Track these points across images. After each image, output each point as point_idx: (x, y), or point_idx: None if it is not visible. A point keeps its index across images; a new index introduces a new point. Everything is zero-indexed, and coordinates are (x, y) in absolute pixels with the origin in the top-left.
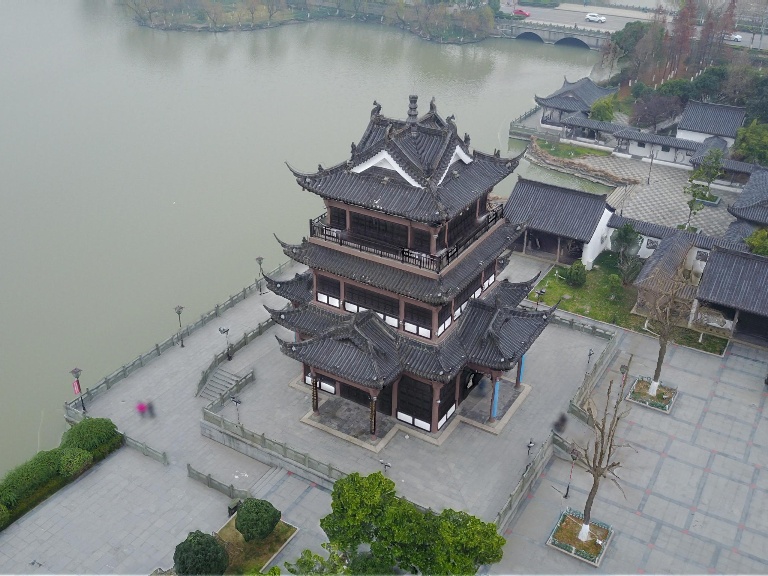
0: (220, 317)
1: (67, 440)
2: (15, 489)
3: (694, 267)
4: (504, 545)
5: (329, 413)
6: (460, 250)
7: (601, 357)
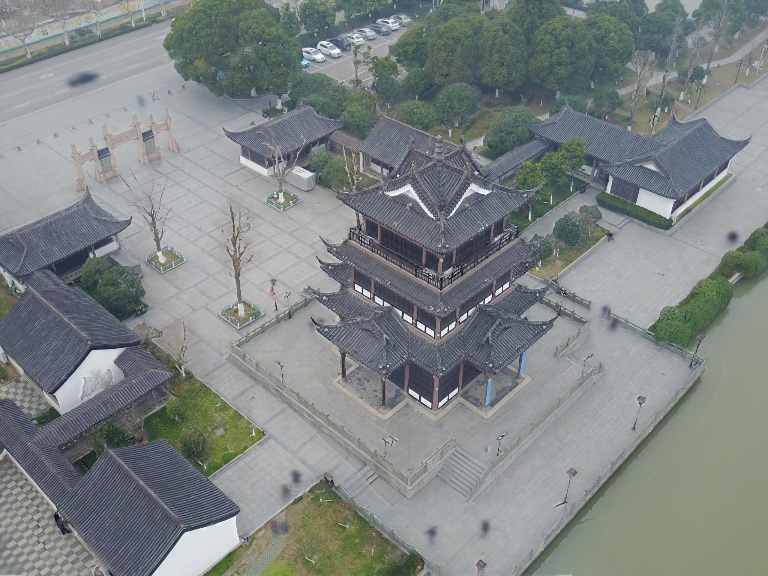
0: None
1: (685, 325)
2: None
3: None
4: None
5: None
6: None
7: (267, 322)
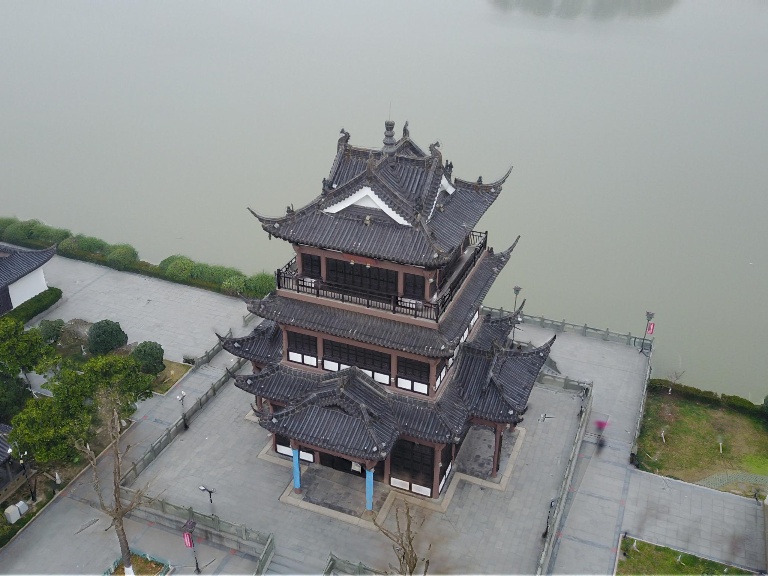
0: None
1: None
2: None
3: None
4: (133, 520)
5: None
6: (325, 293)
7: None
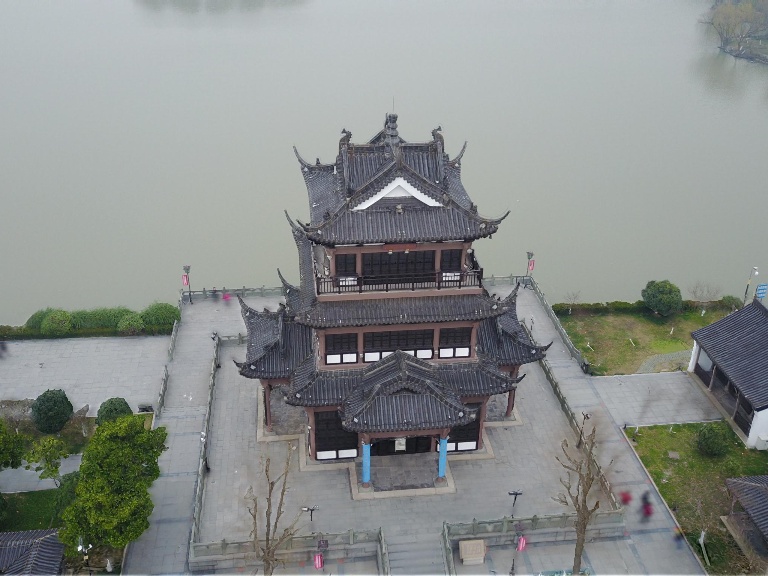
0: None
1: None
2: (86, 319)
3: None
4: (221, 574)
5: None
6: (368, 287)
7: (557, 515)
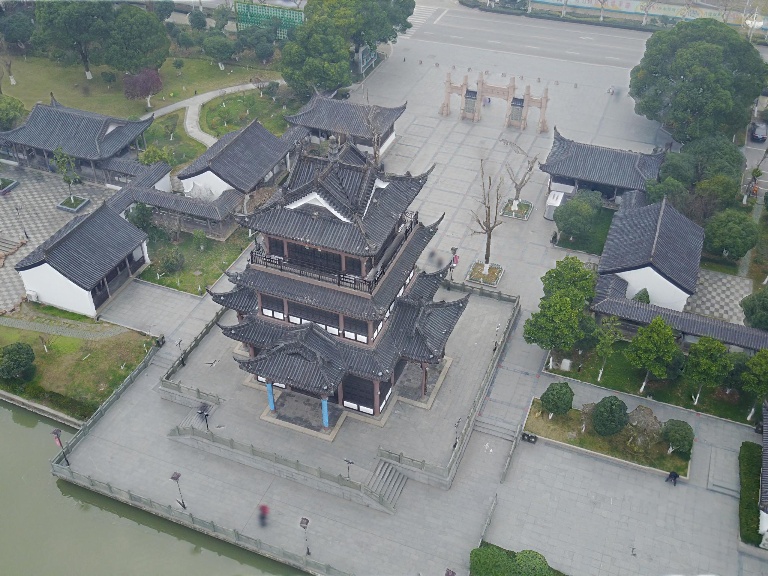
0: None
1: None
2: None
3: (200, 188)
4: None
5: (417, 392)
6: None
7: None
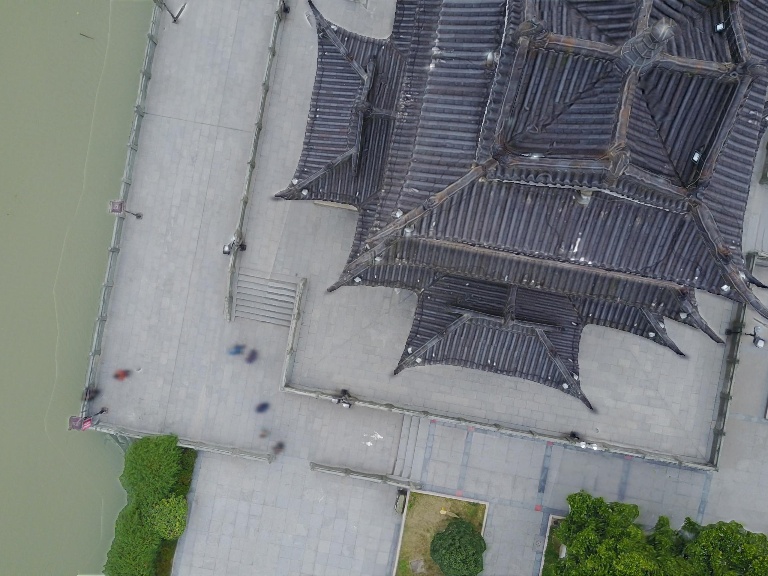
0: (147, 115)
1: (136, 494)
2: None
3: None
4: None
5: None
6: None
7: None
